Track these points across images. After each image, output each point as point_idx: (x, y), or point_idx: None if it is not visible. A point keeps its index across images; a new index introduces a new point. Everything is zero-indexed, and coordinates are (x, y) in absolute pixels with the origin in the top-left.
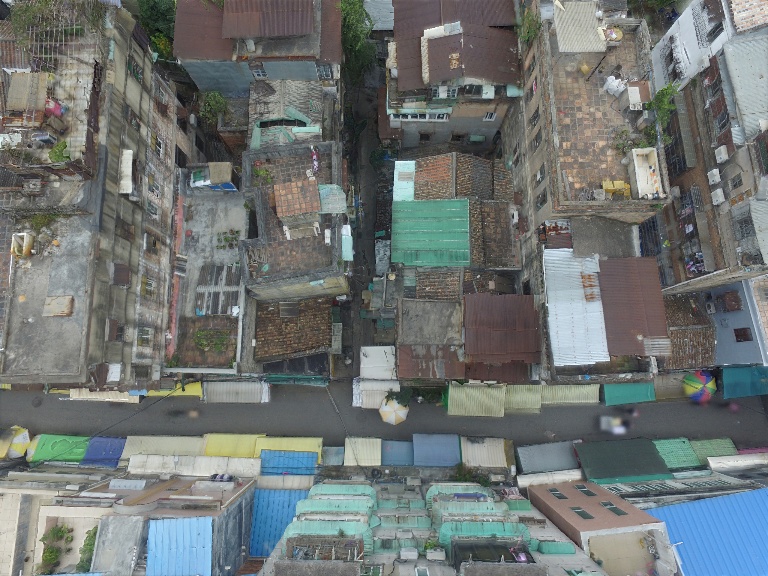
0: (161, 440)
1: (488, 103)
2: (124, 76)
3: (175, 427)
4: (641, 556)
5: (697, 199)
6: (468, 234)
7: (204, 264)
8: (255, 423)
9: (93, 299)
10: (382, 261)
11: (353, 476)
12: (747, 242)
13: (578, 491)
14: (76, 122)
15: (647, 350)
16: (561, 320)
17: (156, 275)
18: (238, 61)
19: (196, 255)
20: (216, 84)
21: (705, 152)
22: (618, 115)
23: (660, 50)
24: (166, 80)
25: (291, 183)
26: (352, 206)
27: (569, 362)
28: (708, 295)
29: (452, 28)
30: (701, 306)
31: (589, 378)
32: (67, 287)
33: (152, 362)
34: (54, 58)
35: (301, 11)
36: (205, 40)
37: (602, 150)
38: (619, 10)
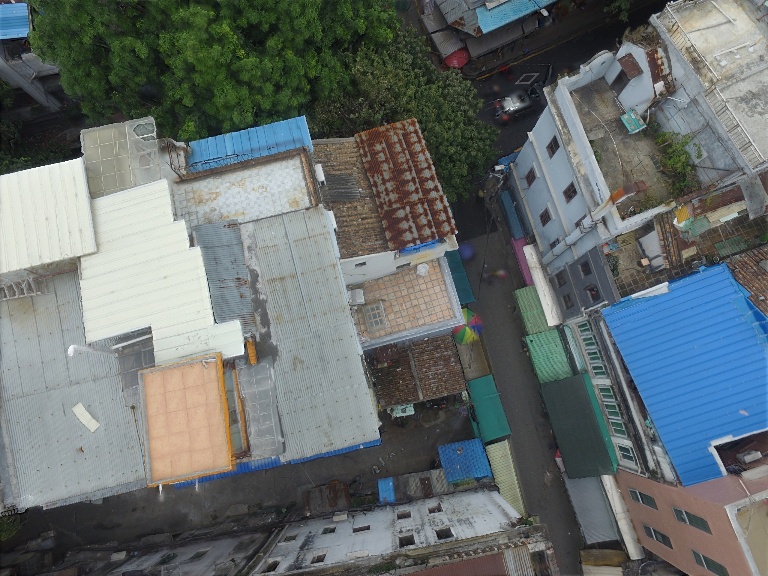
0: None
1: None
2: None
3: None
4: (758, 512)
5: None
6: None
7: None
8: None
9: None
10: None
11: None
12: None
13: (646, 508)
14: None
15: None
16: None
17: None
18: None
19: None
20: None
21: None
22: None
23: None
24: None
25: None
26: None
27: None
28: None
29: None
30: None
31: None
32: None
33: None
34: None
35: None
36: None
37: None
38: None
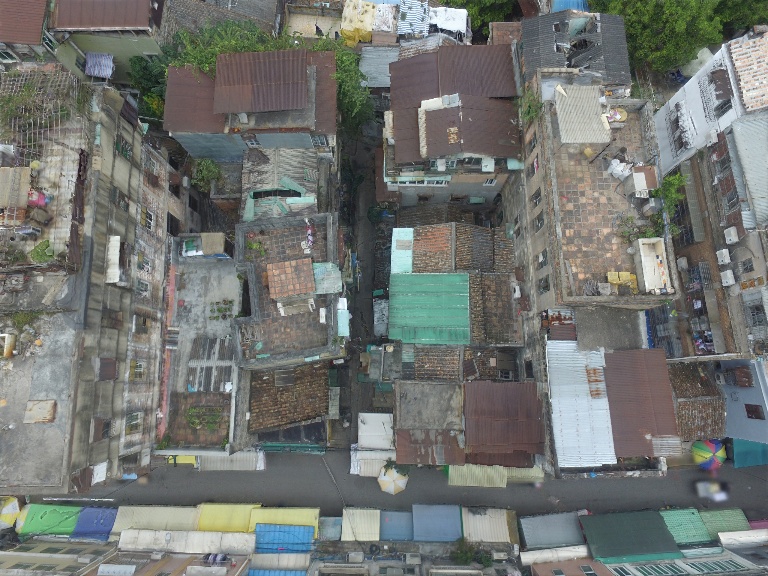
0: (153, 511)
1: (488, 173)
2: (112, 158)
3: (169, 492)
4: None
5: (706, 275)
6: (468, 311)
7: (196, 336)
8: (250, 488)
9: (77, 403)
10: (380, 321)
11: (351, 553)
12: (759, 331)
13: (584, 575)
14: (61, 212)
15: (656, 450)
16: (565, 417)
17: (146, 355)
18: (230, 133)
19: (188, 326)
20: (209, 152)
21: (714, 228)
22: (623, 200)
23: (665, 115)
24: (157, 148)
25: (285, 262)
26: (349, 269)
27: (574, 463)
28: (717, 363)
29: (450, 100)
30: (710, 375)
31: (595, 476)
32: (50, 390)
33: (141, 447)
34: (39, 144)
35: (295, 84)
36: (196, 112)
37: (607, 238)
38: (623, 84)
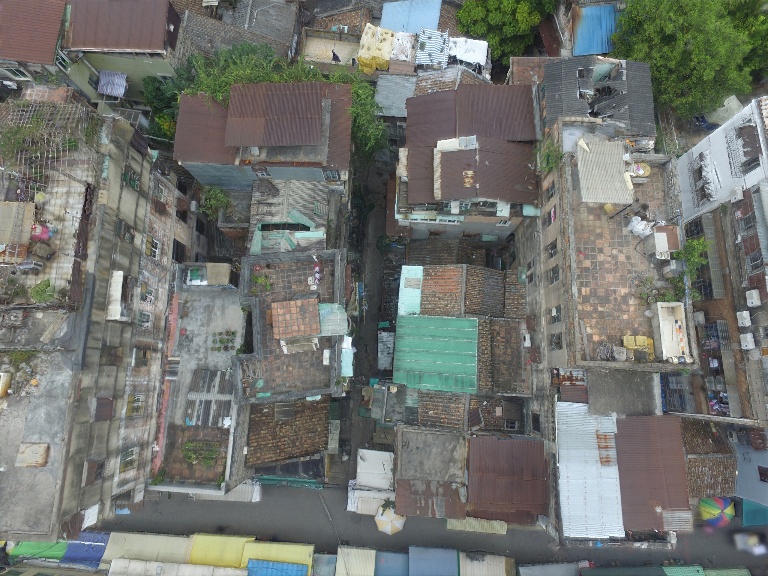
0: (146, 539)
1: None
2: (119, 190)
3: (162, 518)
4: None
5: (724, 335)
6: (476, 358)
7: (197, 366)
8: (245, 518)
9: (70, 447)
10: (385, 354)
11: None
12: None
13: None
14: (64, 246)
15: (666, 524)
16: (573, 484)
17: (145, 388)
18: (241, 165)
19: (189, 356)
20: (218, 180)
21: (734, 287)
22: (643, 259)
23: (688, 163)
24: (166, 174)
25: (290, 302)
26: None
27: (580, 533)
28: None
29: (467, 142)
30: (722, 431)
31: None
32: (43, 433)
33: (135, 484)
34: (45, 175)
35: (309, 118)
36: (207, 142)
37: (624, 298)
38: (647, 136)
